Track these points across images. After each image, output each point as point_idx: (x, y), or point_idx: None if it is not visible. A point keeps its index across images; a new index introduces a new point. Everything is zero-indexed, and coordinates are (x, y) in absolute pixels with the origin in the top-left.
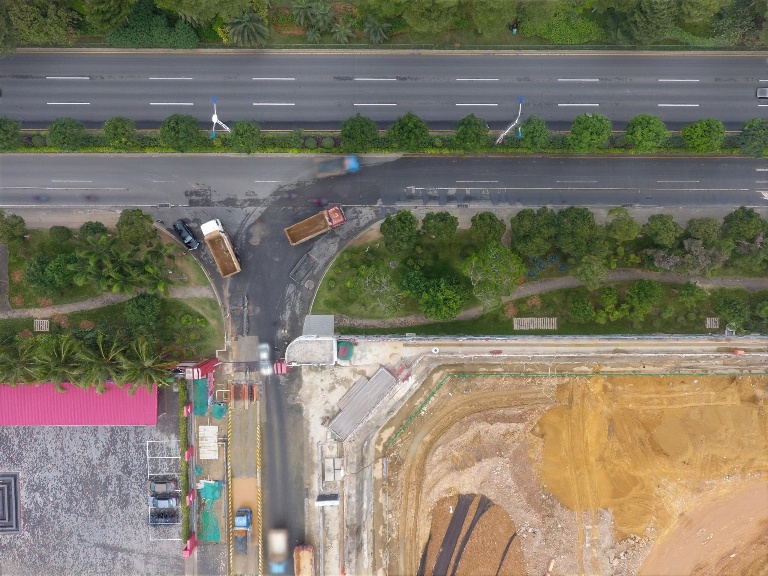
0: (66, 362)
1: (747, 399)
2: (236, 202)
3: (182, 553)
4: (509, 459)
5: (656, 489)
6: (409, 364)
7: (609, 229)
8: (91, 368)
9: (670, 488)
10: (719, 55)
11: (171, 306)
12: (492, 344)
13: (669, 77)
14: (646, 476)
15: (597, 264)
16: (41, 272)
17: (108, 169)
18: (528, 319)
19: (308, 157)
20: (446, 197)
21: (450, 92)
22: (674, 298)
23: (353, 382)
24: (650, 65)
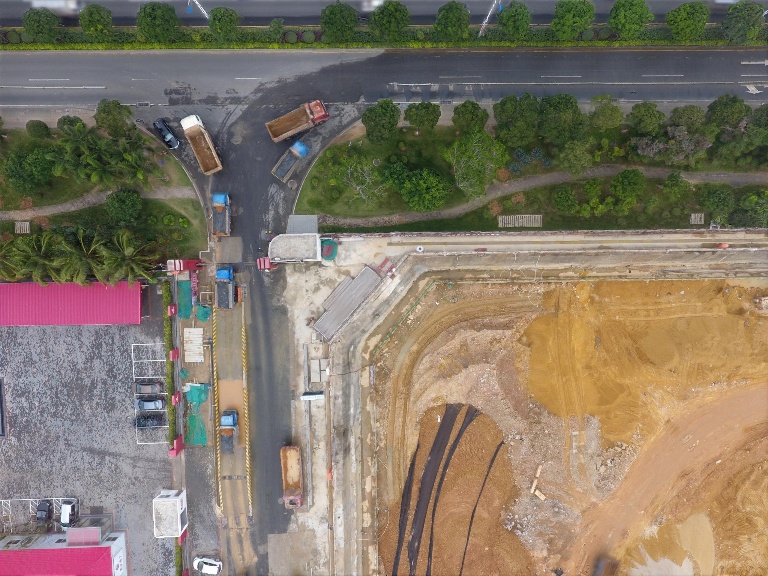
0: (46, 255)
1: (734, 312)
2: (216, 100)
3: (169, 452)
4: (496, 365)
5: (642, 397)
6: (394, 263)
7: (592, 117)
8: (71, 258)
9: (656, 396)
10: None
11: (153, 207)
12: (477, 242)
13: None
14: (633, 384)
15: (580, 148)
16: (18, 164)
17: (85, 67)
18: (513, 217)
19: (289, 53)
20: (429, 93)
21: None
22: (659, 194)
23: (338, 282)
24: None
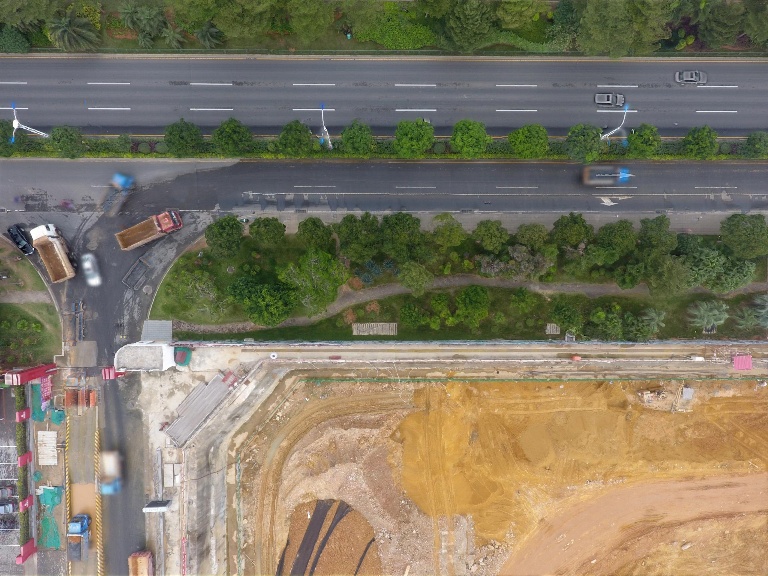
0: None
1: (617, 404)
2: (73, 207)
3: (15, 559)
4: (363, 465)
5: (516, 495)
6: (248, 370)
7: (435, 235)
8: None
9: (530, 494)
10: (556, 61)
11: (7, 311)
12: (331, 350)
13: (507, 82)
14: (506, 482)
15: (416, 270)
16: None
17: None
18: (367, 325)
19: (144, 162)
20: (284, 202)
21: (287, 97)
22: None
23: (192, 388)
24: (487, 70)
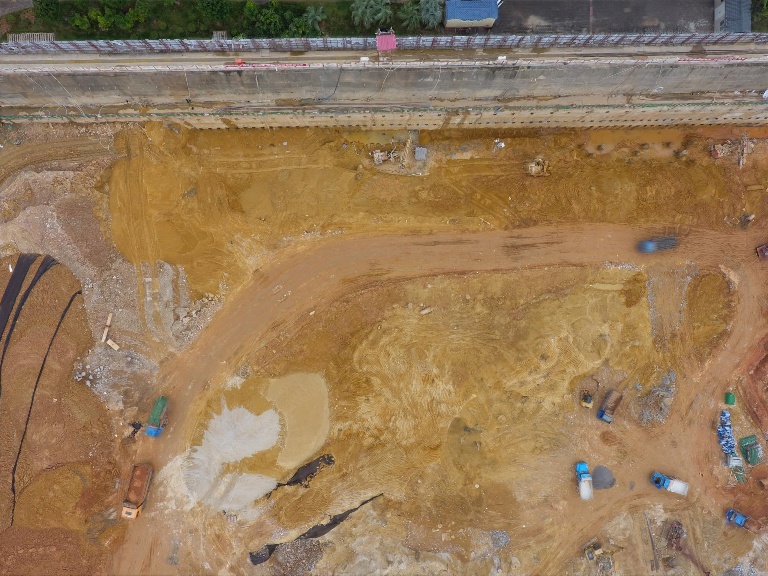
0: None
1: (352, 168)
2: None
3: None
4: (56, 207)
5: (229, 245)
6: None
7: None
8: None
9: (244, 244)
10: None
11: None
12: None
13: None
14: (218, 232)
15: None
16: None
17: None
18: (23, 35)
19: None
20: None
21: None
22: (176, 10)
23: None
24: None
